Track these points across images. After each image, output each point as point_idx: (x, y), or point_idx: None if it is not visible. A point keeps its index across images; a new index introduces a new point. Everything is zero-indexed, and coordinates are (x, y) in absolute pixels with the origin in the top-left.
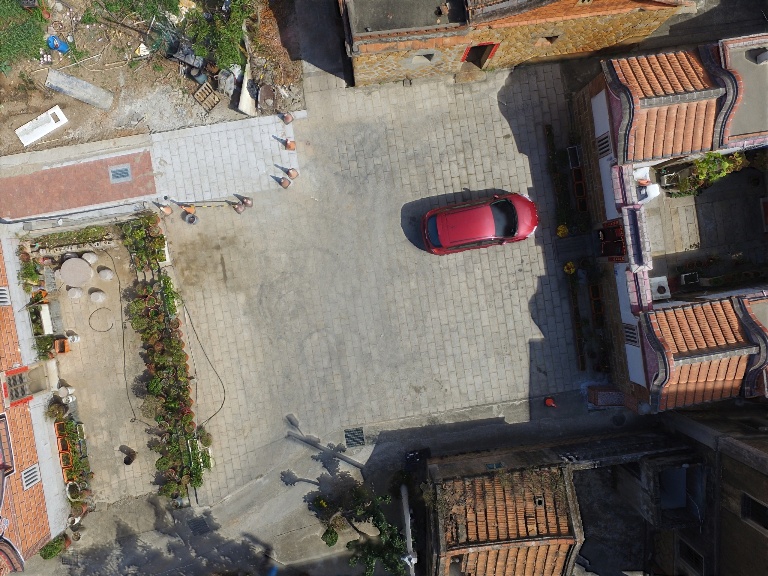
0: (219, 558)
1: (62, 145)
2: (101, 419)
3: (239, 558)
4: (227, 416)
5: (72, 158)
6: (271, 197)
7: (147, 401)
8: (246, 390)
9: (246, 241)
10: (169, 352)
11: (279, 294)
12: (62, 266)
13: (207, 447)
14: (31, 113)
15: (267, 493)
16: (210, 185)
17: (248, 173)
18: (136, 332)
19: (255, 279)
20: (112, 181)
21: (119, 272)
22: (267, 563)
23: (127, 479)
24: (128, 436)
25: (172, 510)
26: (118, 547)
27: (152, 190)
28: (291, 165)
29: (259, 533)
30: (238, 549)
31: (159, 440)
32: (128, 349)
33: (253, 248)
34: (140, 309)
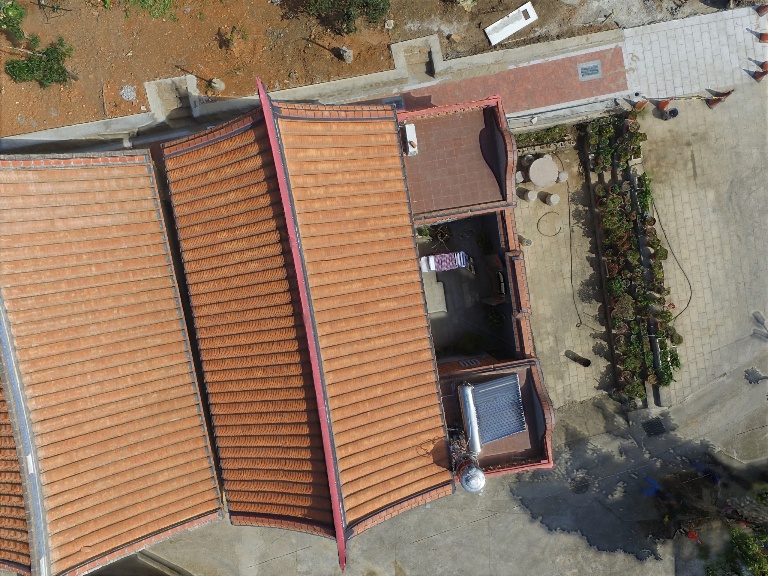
0: (675, 459)
1: (533, 43)
2: (547, 324)
3: (697, 458)
4: (693, 315)
5: (540, 56)
6: (744, 91)
7: (627, 298)
8: (713, 288)
9: (717, 137)
10: (637, 251)
11: (749, 190)
12: (532, 166)
13: (675, 346)
14: (502, 11)
15: (730, 392)
16: (682, 80)
17: (721, 67)
18: (583, 236)
19: (725, 175)
20: (581, 79)
21: (568, 175)
22: (726, 462)
23: (571, 384)
24: (573, 341)
25: (622, 413)
26: (567, 451)
27: (623, 87)
28: (764, 58)
29: (719, 432)
30: (696, 449)
31: (604, 344)
32: (575, 253)
33: (724, 144)
34: (615, 207)
